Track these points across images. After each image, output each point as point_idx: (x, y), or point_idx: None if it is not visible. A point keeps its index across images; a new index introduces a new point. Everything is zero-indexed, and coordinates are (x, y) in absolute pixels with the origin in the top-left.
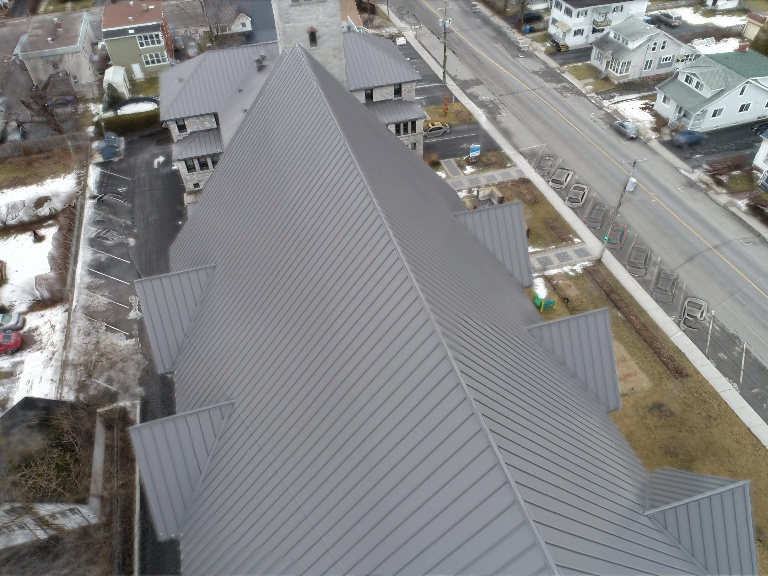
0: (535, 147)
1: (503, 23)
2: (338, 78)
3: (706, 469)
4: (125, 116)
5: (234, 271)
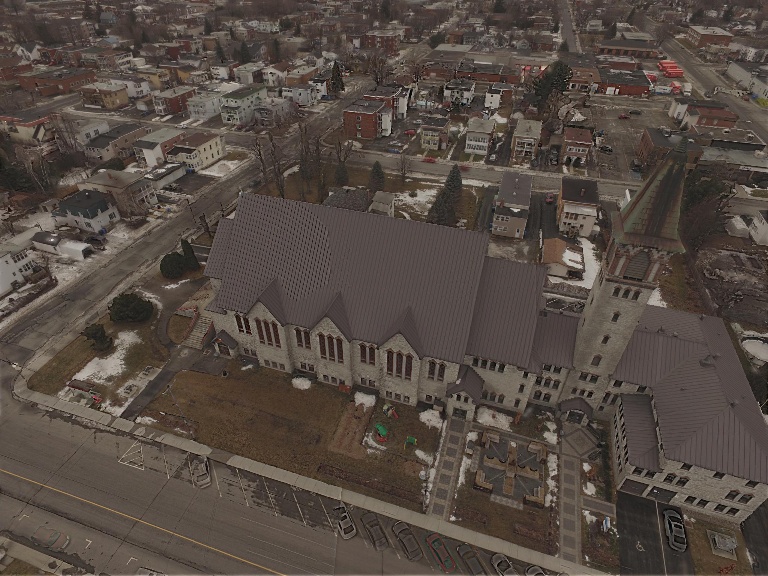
0: None
1: None
2: None
3: (282, 430)
4: (730, 332)
5: None
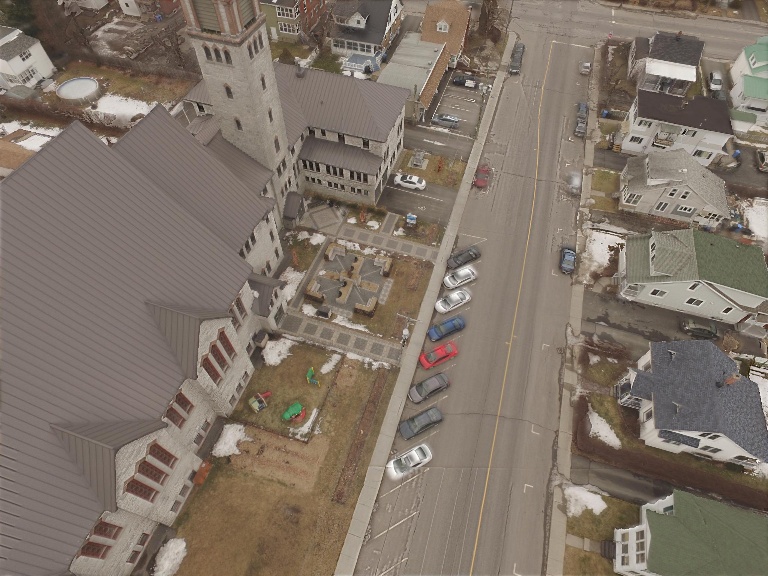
0: (474, 238)
1: (595, 96)
2: (254, 128)
3: None
4: None
5: None
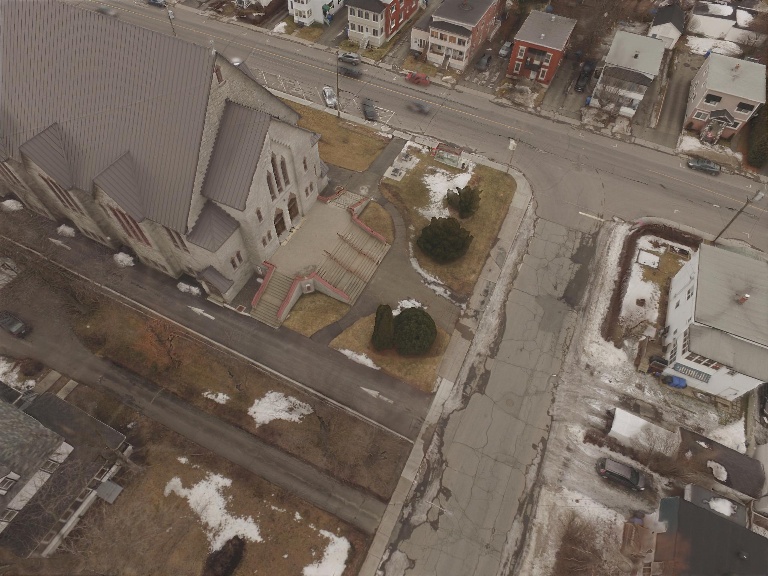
0: None
1: None
2: None
3: None
4: None
5: (6, 87)
